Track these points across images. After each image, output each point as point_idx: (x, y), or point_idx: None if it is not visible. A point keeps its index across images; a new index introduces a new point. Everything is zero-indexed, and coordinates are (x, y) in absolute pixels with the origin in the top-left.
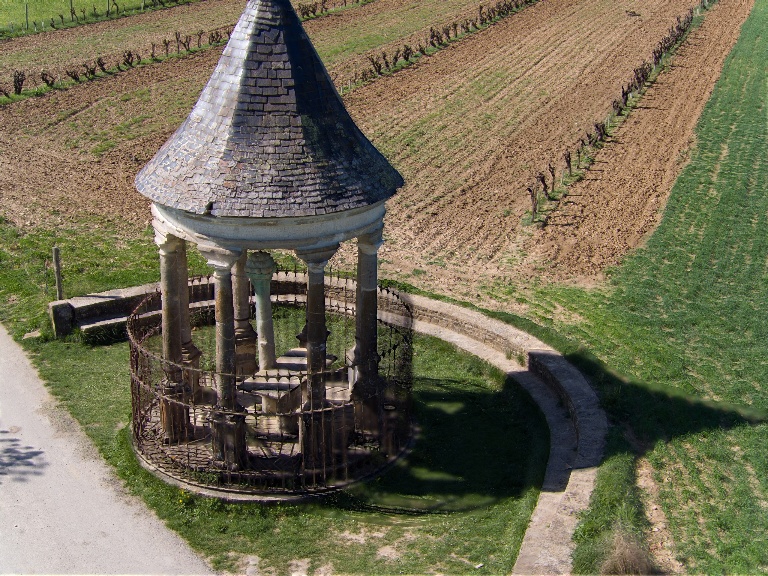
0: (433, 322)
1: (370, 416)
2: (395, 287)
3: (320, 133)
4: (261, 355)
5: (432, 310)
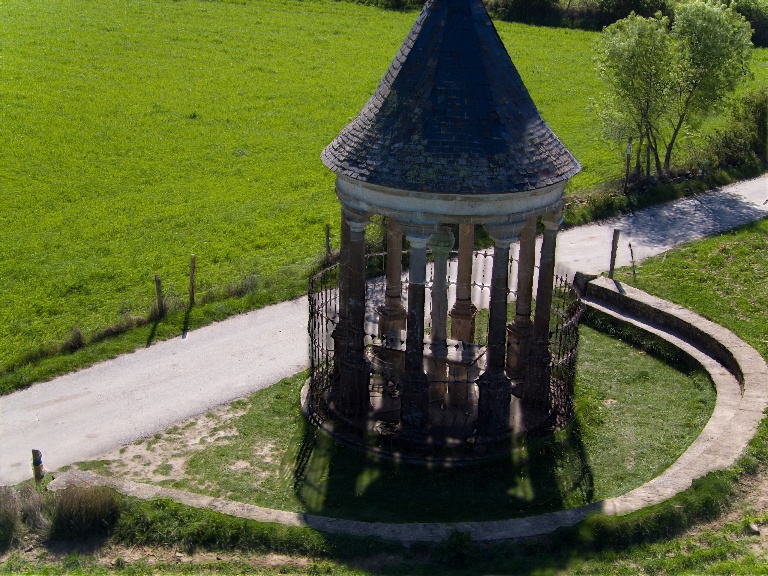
0: None
1: None
2: None
3: (396, 110)
4: None
5: None
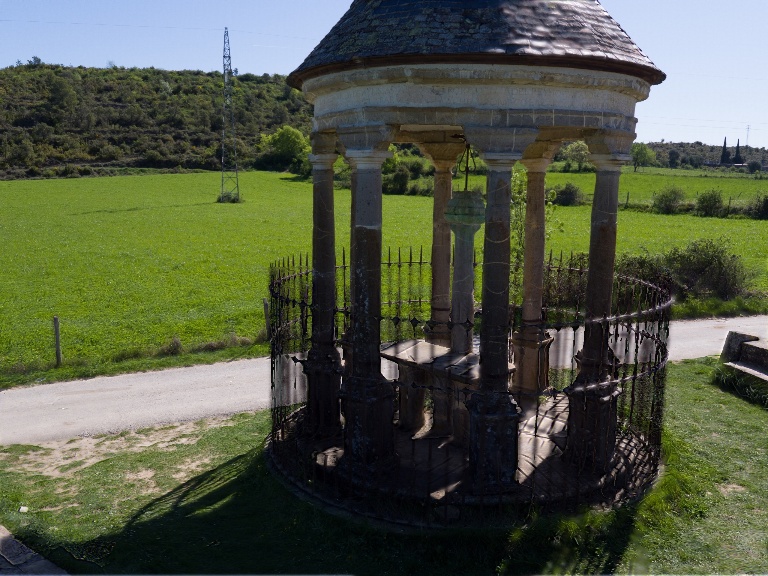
0: None
1: None
2: None
3: None
4: None
5: None
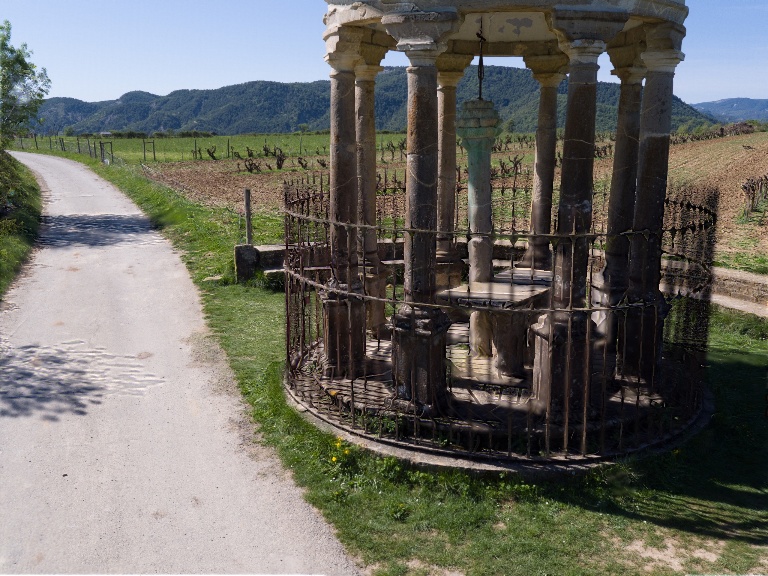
0: (675, 283)
1: (644, 353)
2: None
3: None
4: (472, 260)
5: (674, 268)
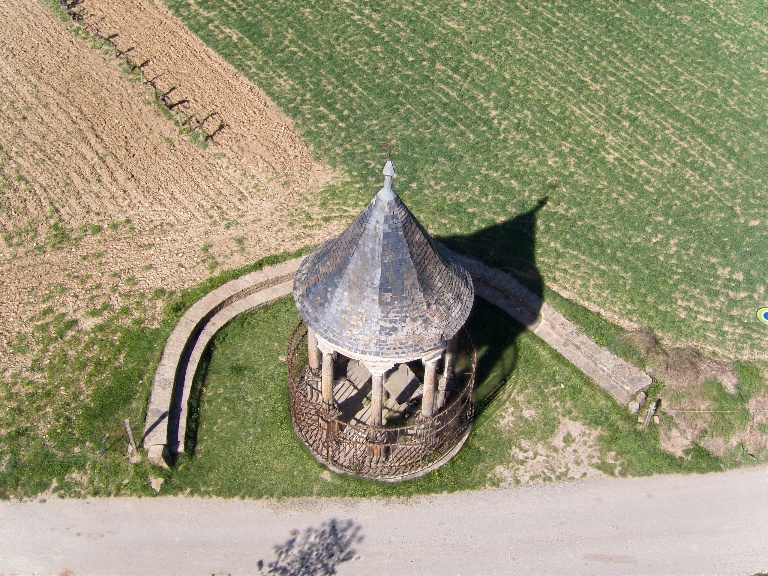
0: None
1: None
2: (266, 265)
3: None
4: None
5: None
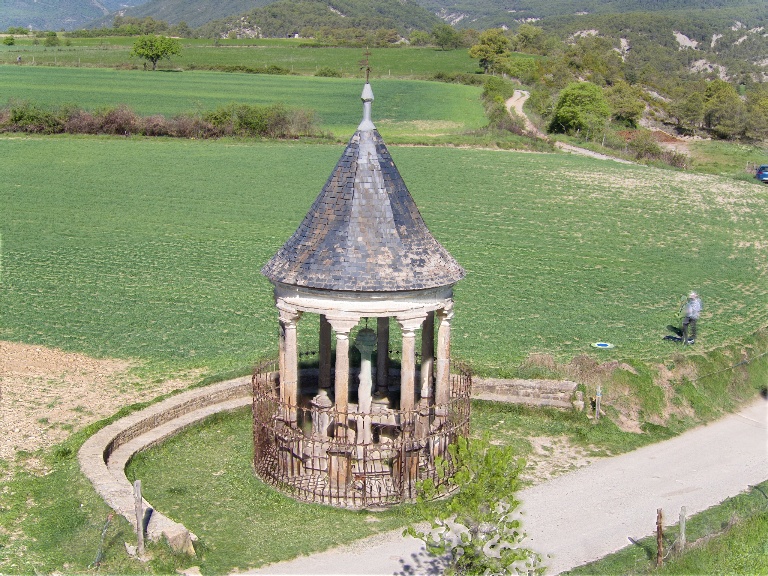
0: (187, 412)
1: None
2: (132, 411)
3: None
4: None
5: (185, 402)
